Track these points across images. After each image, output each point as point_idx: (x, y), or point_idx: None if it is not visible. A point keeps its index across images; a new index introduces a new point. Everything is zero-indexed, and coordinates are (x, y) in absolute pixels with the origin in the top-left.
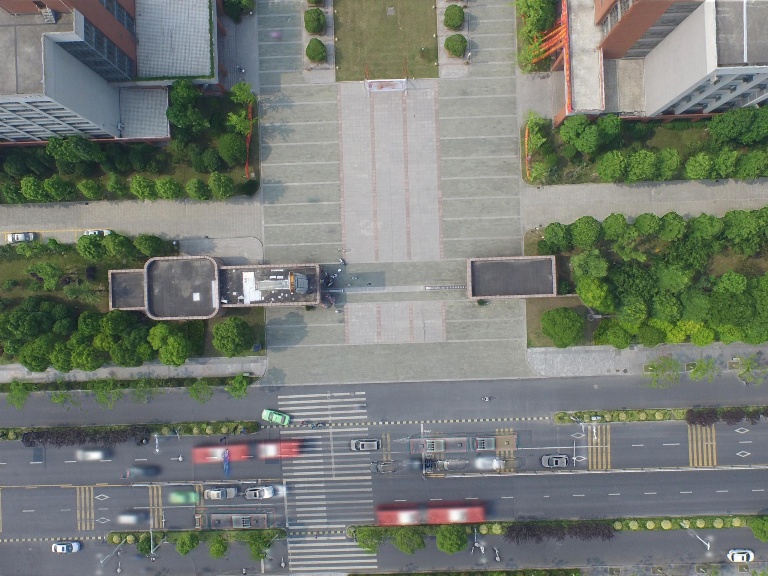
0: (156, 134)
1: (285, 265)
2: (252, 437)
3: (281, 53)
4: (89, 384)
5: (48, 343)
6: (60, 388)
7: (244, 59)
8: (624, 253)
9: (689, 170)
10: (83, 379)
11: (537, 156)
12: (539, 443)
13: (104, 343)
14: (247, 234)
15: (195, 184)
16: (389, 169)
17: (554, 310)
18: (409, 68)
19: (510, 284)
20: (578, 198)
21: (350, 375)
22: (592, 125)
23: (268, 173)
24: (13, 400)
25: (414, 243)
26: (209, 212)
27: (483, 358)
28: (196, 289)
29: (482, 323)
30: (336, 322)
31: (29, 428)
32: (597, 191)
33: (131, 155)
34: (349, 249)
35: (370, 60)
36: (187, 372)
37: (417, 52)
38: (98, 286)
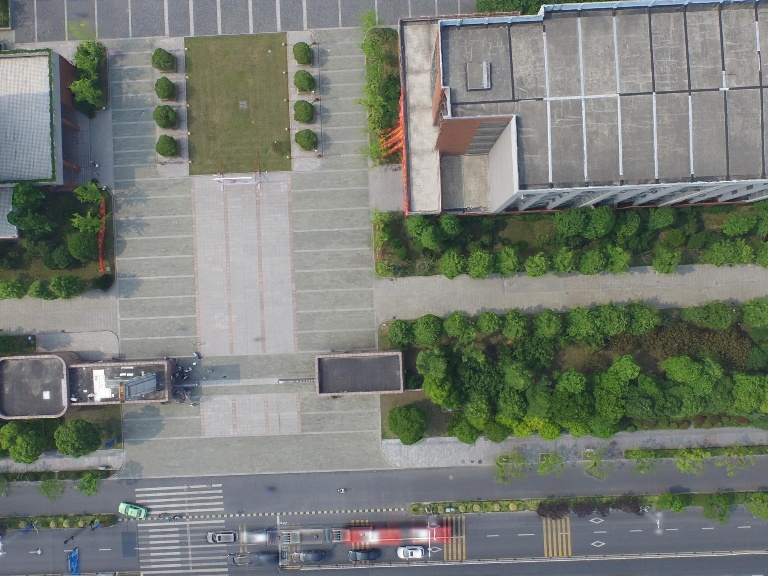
0: (5, 233)
1: (134, 363)
2: (109, 530)
3: (135, 147)
4: None
5: None
6: None
7: (98, 153)
8: (466, 352)
9: (527, 270)
10: None
11: (389, 248)
12: (394, 534)
13: None
14: (103, 328)
15: (36, 288)
16: (243, 262)
17: (397, 409)
18: (262, 161)
19: (358, 380)
20: (431, 290)
21: (207, 467)
22: (429, 227)
23: (123, 267)
24: None
25: (268, 336)
26: (65, 306)
27: (338, 450)
28: (46, 387)
29: (337, 415)
30: (192, 415)
31: None
32: (450, 283)
33: None
34: (204, 342)
35: (223, 154)
36: (45, 465)
37: (270, 145)
38: None
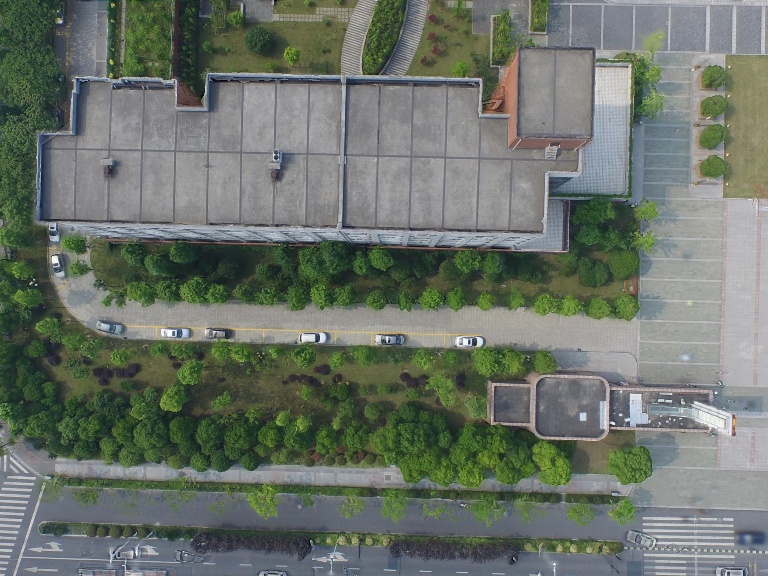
0: (550, 246)
1: (678, 390)
2: (615, 558)
3: (667, 165)
4: (453, 494)
5: (436, 458)
6: (422, 496)
7: None
8: None
9: None
10: (443, 487)
11: None
12: None
13: (492, 461)
14: (621, 349)
15: (608, 307)
16: None
17: None
18: None
19: None
20: None
21: (719, 500)
22: None
23: (647, 288)
24: (392, 512)
25: None
26: (583, 324)
27: None
28: (583, 409)
29: None
30: (708, 445)
31: (386, 535)
32: None
33: (523, 267)
34: (727, 371)
35: (761, 178)
36: (550, 487)
37: None
38: (467, 394)
